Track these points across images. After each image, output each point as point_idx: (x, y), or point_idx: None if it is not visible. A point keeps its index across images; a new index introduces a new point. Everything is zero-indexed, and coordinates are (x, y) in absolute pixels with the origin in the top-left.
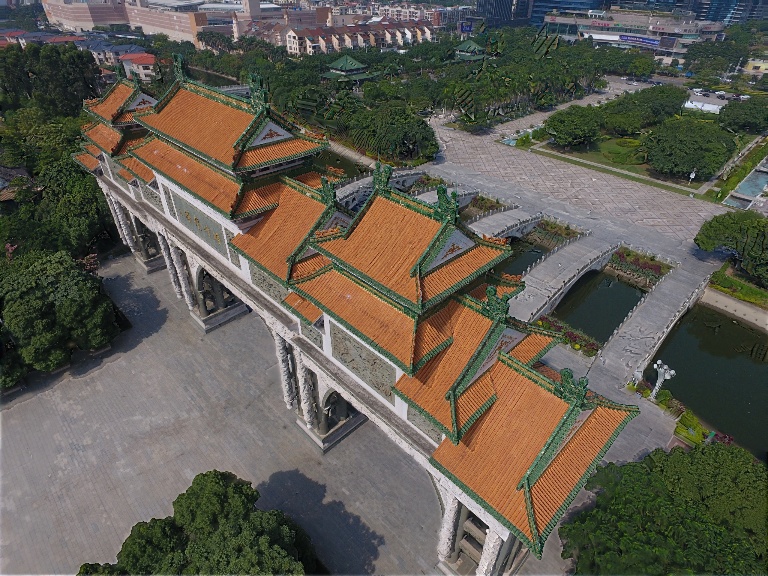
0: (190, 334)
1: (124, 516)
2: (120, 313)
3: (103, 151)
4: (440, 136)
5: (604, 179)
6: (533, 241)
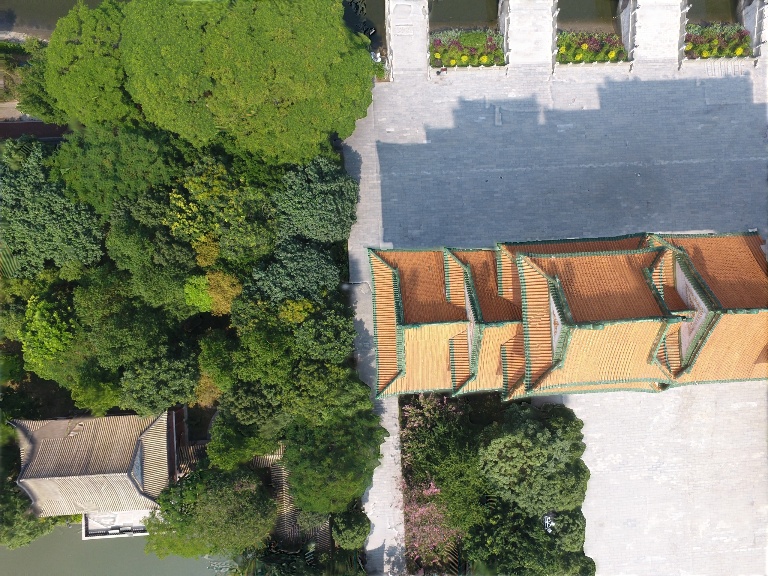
0: None
1: (739, 454)
2: None
3: None
4: None
5: None
6: None
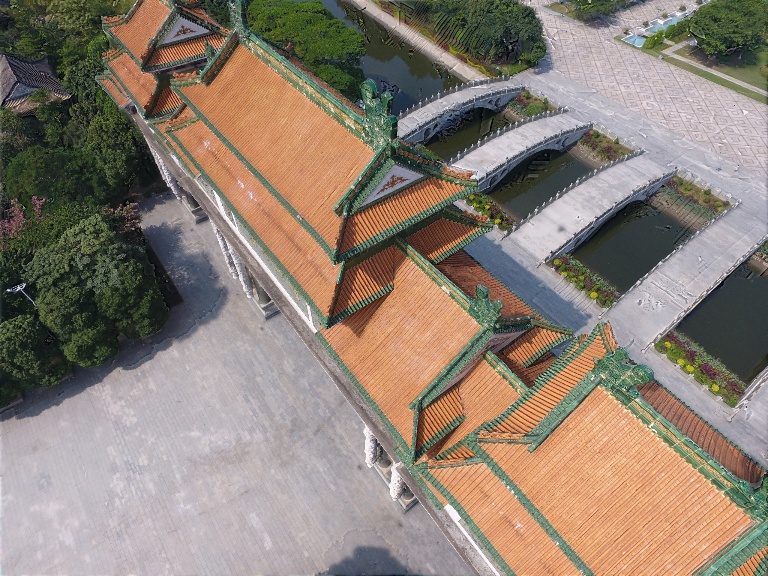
0: (248, 319)
1: (188, 569)
2: (168, 280)
3: (134, 102)
4: (548, 31)
5: (759, 112)
6: (658, 205)
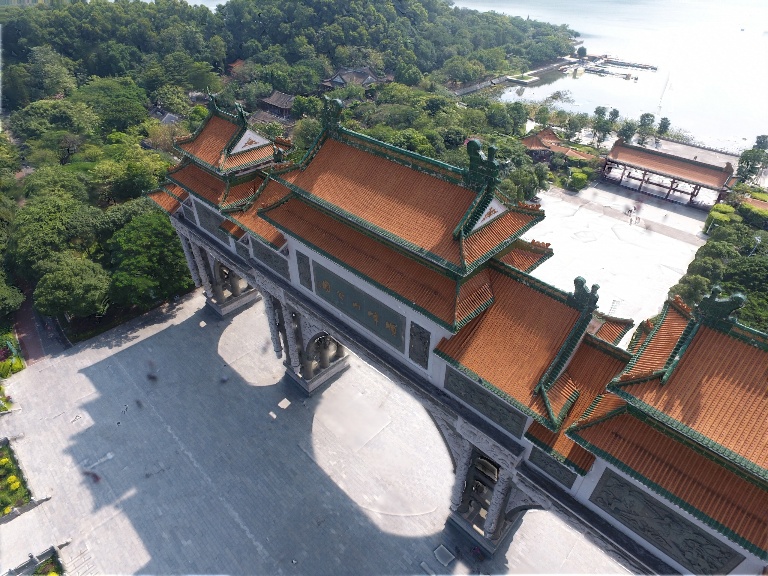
0: None
1: None
2: None
3: None
4: None
5: None
6: None
